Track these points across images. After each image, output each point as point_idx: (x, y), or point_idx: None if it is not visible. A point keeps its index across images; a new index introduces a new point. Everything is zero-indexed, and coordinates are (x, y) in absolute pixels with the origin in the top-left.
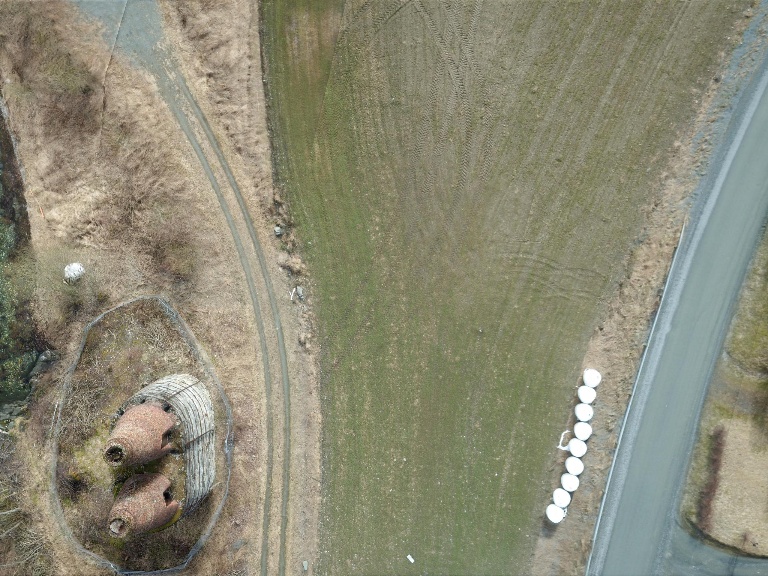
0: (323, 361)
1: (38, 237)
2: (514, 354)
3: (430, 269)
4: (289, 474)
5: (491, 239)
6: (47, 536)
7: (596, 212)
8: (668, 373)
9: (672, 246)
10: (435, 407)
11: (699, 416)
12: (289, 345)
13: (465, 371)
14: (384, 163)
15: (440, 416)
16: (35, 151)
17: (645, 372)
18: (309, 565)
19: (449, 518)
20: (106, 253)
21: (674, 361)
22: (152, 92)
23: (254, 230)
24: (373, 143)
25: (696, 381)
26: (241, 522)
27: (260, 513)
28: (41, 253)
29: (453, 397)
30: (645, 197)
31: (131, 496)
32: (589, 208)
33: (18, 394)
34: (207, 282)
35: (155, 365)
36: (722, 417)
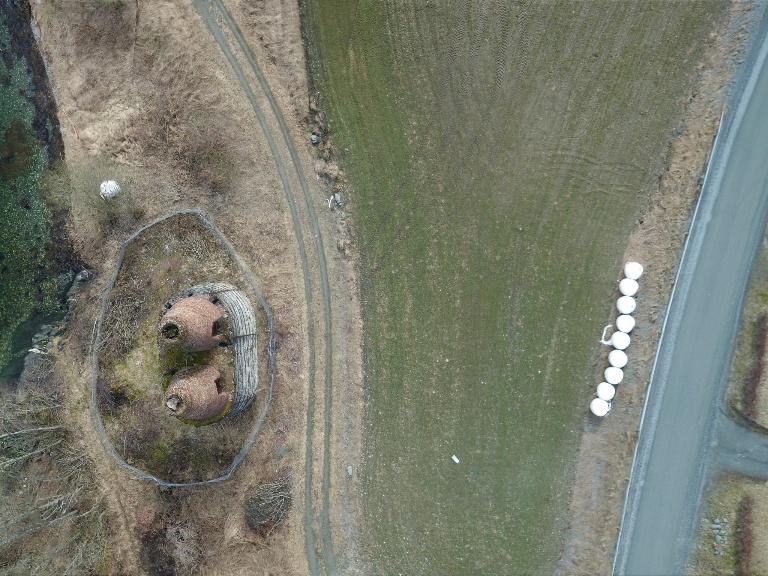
0: (363, 267)
1: (72, 157)
2: (555, 251)
3: (468, 170)
4: (331, 380)
5: (529, 137)
6: (89, 453)
7: (634, 106)
8: (710, 262)
9: (711, 135)
10: (477, 307)
11: (741, 304)
12: (328, 252)
13: (506, 270)
14: (420, 66)
15: (482, 316)
16: (67, 71)
17: (687, 261)
18: (353, 470)
19: (493, 417)
20: (141, 170)
21: (716, 249)
22: (185, 5)
23: (290, 139)
24: (408, 47)
25: (738, 269)
26: (284, 429)
27: (303, 419)
28: (76, 173)
29: (494, 296)
30: (682, 89)
31: (185, 379)
32: (627, 102)
33: (55, 315)
34: (244, 193)
35: (195, 275)
36: (765, 304)
